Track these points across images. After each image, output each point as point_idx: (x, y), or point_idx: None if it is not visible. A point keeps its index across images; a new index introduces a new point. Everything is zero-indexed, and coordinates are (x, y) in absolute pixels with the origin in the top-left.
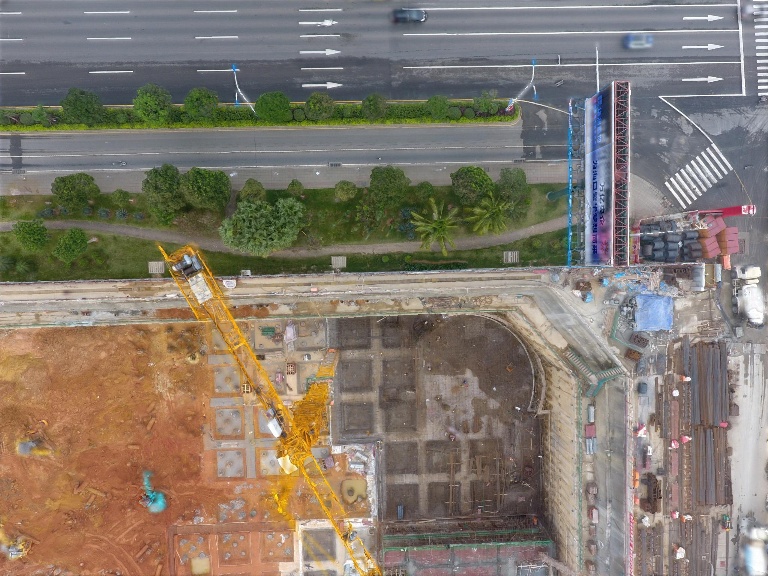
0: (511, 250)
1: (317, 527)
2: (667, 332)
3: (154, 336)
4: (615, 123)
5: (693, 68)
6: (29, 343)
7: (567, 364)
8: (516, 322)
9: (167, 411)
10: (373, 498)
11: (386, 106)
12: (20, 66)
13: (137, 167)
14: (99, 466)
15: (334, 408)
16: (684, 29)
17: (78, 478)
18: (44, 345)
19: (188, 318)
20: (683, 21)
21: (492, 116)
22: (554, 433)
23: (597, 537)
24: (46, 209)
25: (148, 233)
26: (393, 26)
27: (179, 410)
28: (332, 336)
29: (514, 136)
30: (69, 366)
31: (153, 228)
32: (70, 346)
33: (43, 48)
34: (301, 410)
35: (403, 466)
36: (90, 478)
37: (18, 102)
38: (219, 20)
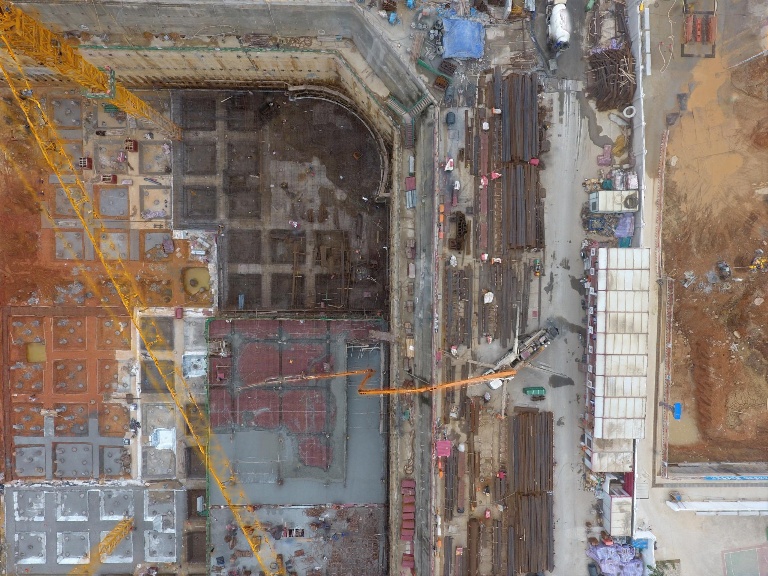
0: None
1: (156, 315)
2: (477, 61)
3: None
4: None
5: None
6: None
7: (387, 111)
8: (350, 87)
9: (4, 185)
10: (216, 289)
11: None
12: None
13: None
14: None
15: (176, 191)
16: None
17: None
18: None
19: None
20: None
21: None
22: (392, 212)
23: (415, 295)
24: None
25: None
26: None
27: (16, 184)
28: (176, 115)
29: None
30: None
31: None
32: None
33: None
34: None
35: (247, 257)
36: None
37: None
38: None
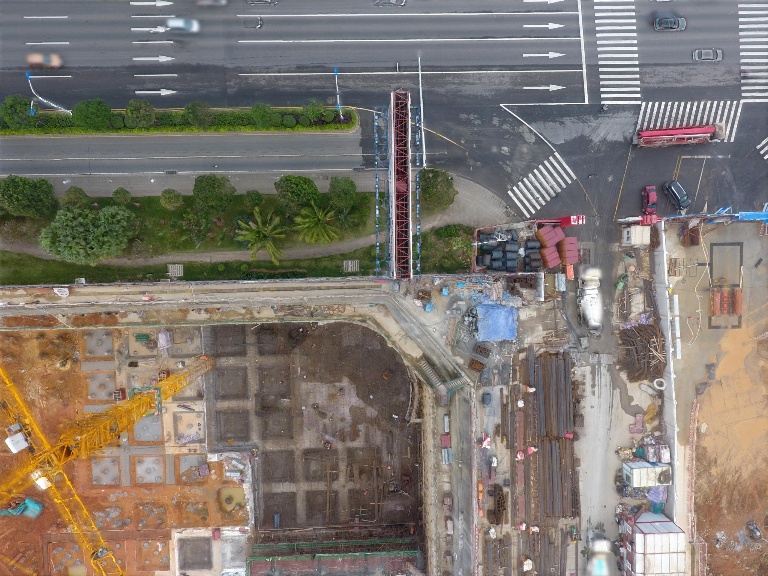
0: (351, 259)
1: (193, 535)
2: (511, 342)
3: (26, 342)
4: (395, 134)
5: (534, 76)
6: None
7: (421, 373)
8: None
9: (39, 418)
10: (251, 506)
11: (209, 114)
12: None
13: None
14: None
15: (209, 416)
16: (524, 37)
17: None
18: None
19: (35, 326)
20: (523, 29)
21: (328, 124)
22: (425, 442)
23: (453, 548)
24: None
25: None
26: (228, 33)
27: (51, 417)
28: (207, 343)
29: (353, 144)
30: None
31: None
32: None
33: None
34: None
35: (281, 474)
36: None
37: None
38: (50, 26)
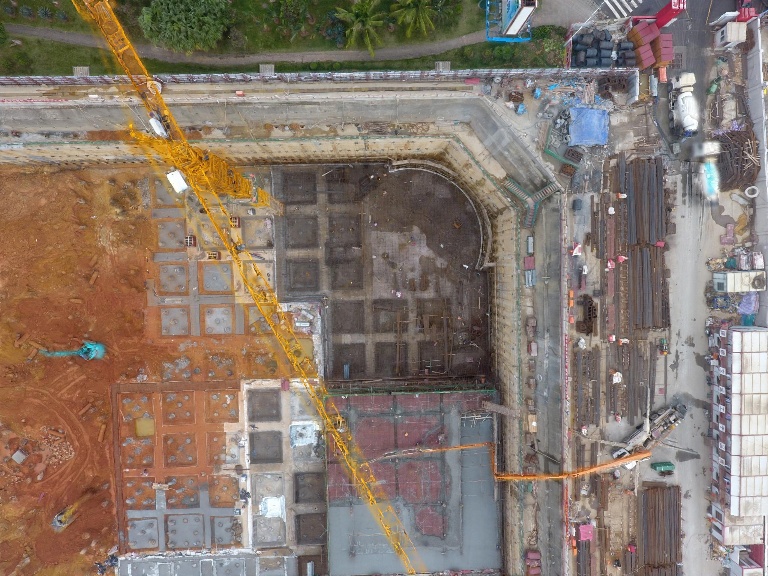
0: (442, 60)
1: (262, 387)
2: (602, 147)
3: (97, 188)
4: None
5: None
6: None
7: (505, 193)
8: (458, 164)
9: (110, 265)
10: (320, 359)
11: None
12: None
13: None
14: (40, 317)
15: (279, 264)
16: None
17: (19, 330)
18: None
19: None
20: None
21: None
22: (499, 283)
23: (536, 372)
24: None
25: (73, 37)
26: None
27: (122, 264)
28: (277, 190)
29: None
30: (8, 210)
31: (78, 32)
32: (10, 191)
33: None
34: None
35: (350, 326)
36: (30, 329)
37: None
38: None
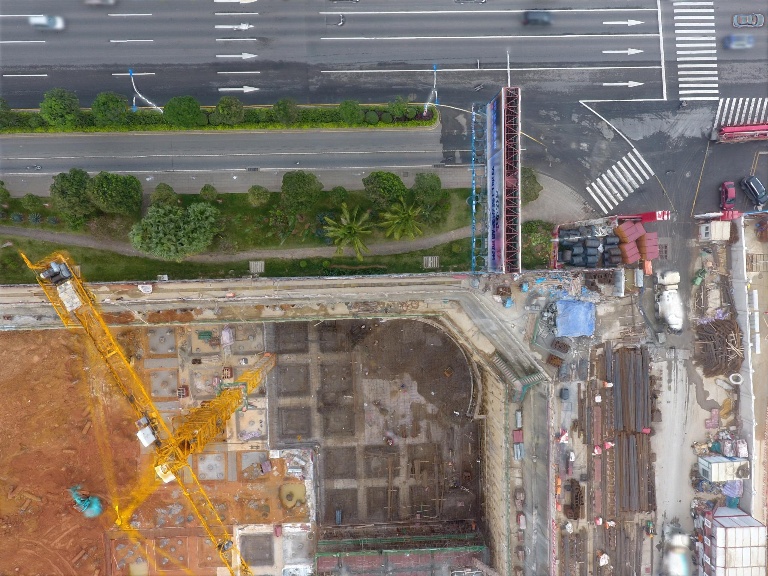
0: (431, 255)
1: (255, 532)
2: (589, 338)
3: (89, 340)
4: (505, 129)
5: (613, 73)
6: None
7: (494, 369)
8: (448, 327)
9: (103, 415)
10: (312, 503)
11: None
12: None
13: (52, 171)
14: (33, 471)
15: (271, 412)
16: (604, 34)
17: (12, 483)
18: None
19: (111, 323)
20: (603, 25)
21: (410, 120)
22: (489, 438)
23: (525, 543)
24: None
25: (64, 237)
26: (310, 30)
27: (115, 414)
28: (269, 340)
29: (433, 141)
30: (0, 370)
31: (69, 232)
32: (2, 350)
33: None
34: (195, 417)
35: (342, 471)
36: (24, 483)
37: None
38: (134, 23)
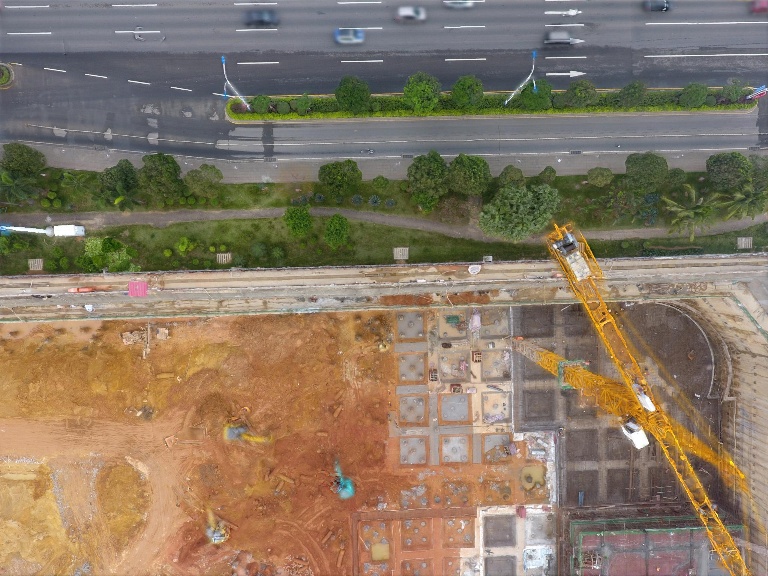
0: (745, 236)
1: (498, 513)
2: None
3: (342, 325)
4: None
5: None
6: (226, 331)
7: None
8: (714, 309)
9: (354, 399)
10: (552, 485)
11: None
12: (274, 56)
13: (384, 155)
14: (291, 453)
15: (517, 396)
16: None
17: (269, 465)
18: (242, 333)
19: (412, 305)
20: None
21: (732, 104)
22: (743, 419)
23: None
24: (301, 196)
25: (394, 220)
26: (635, 15)
27: (366, 398)
28: (516, 324)
29: (750, 124)
30: (269, 354)
31: (399, 215)
32: (268, 334)
33: (297, 38)
34: (609, 389)
35: (582, 453)
36: (283, 464)
37: (271, 91)
38: (467, 10)
